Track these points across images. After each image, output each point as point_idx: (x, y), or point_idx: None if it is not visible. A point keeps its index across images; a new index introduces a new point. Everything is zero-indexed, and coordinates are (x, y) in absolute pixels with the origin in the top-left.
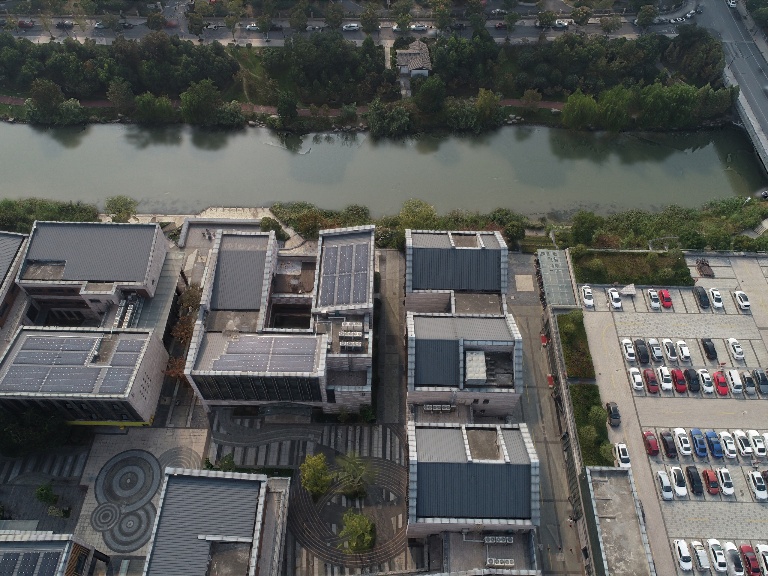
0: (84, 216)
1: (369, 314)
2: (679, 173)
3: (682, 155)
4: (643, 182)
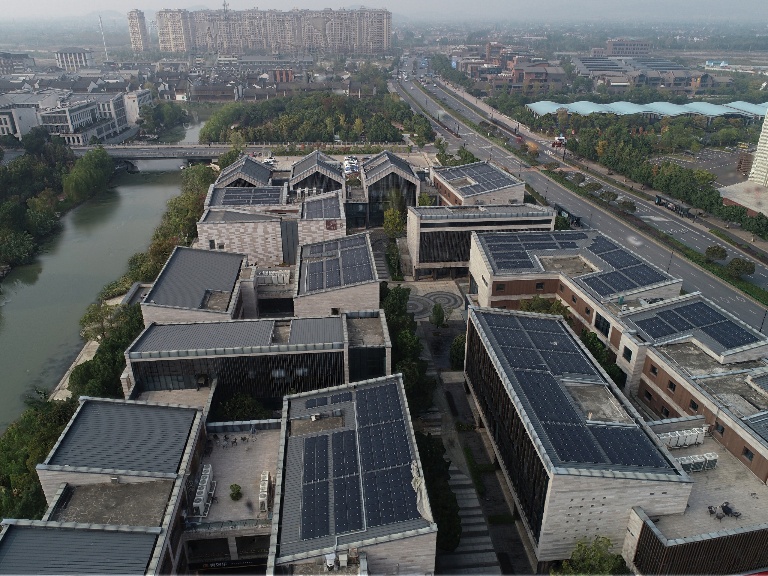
0: None
1: None
2: (152, 182)
3: (135, 181)
4: (155, 190)
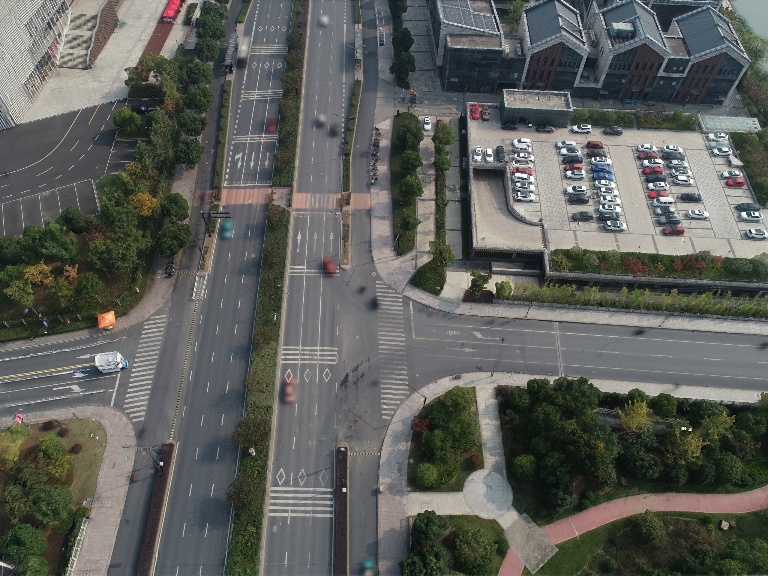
0: None
1: (649, 4)
2: None
3: None
4: None
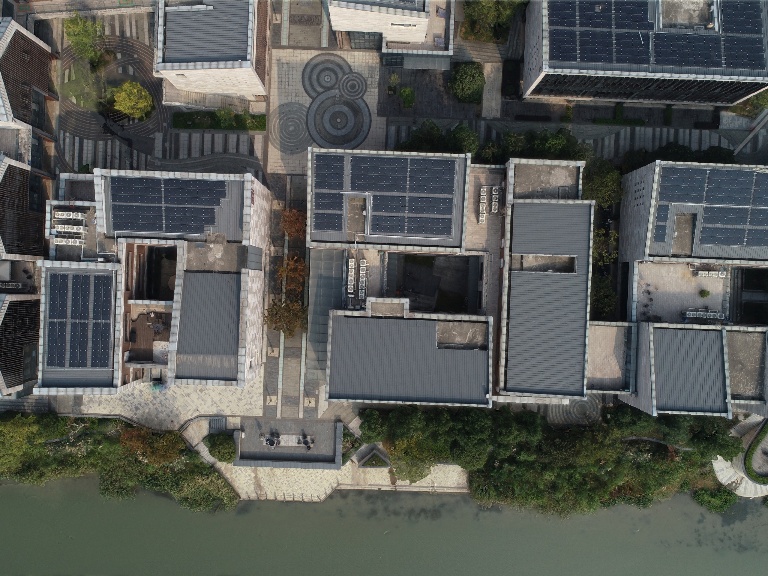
0: (467, 462)
1: None
2: None
3: None
4: None
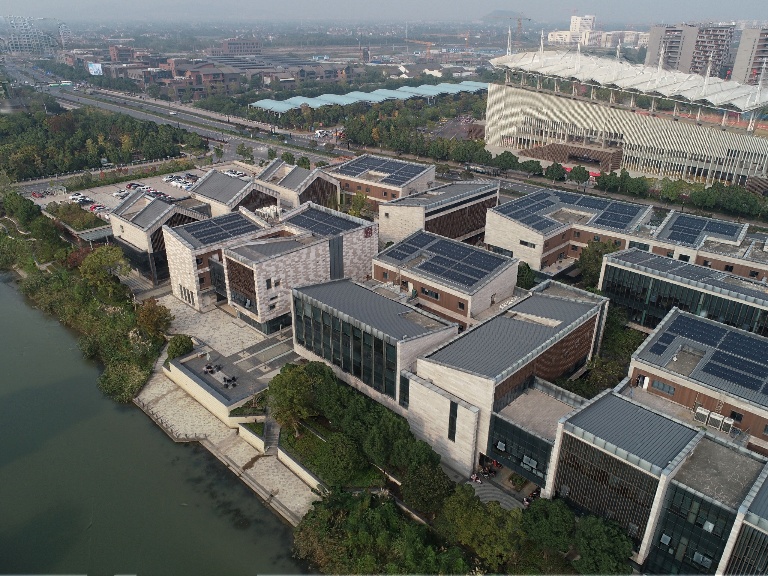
0: None
1: None
2: None
3: None
4: None
